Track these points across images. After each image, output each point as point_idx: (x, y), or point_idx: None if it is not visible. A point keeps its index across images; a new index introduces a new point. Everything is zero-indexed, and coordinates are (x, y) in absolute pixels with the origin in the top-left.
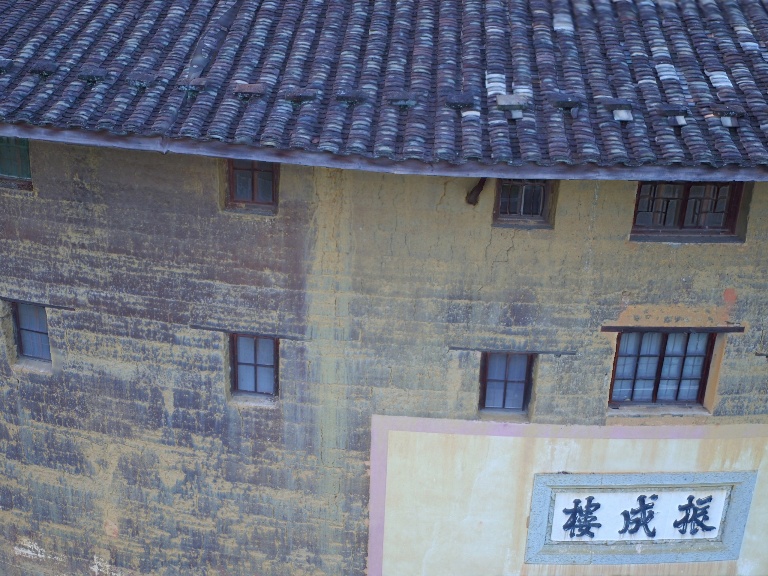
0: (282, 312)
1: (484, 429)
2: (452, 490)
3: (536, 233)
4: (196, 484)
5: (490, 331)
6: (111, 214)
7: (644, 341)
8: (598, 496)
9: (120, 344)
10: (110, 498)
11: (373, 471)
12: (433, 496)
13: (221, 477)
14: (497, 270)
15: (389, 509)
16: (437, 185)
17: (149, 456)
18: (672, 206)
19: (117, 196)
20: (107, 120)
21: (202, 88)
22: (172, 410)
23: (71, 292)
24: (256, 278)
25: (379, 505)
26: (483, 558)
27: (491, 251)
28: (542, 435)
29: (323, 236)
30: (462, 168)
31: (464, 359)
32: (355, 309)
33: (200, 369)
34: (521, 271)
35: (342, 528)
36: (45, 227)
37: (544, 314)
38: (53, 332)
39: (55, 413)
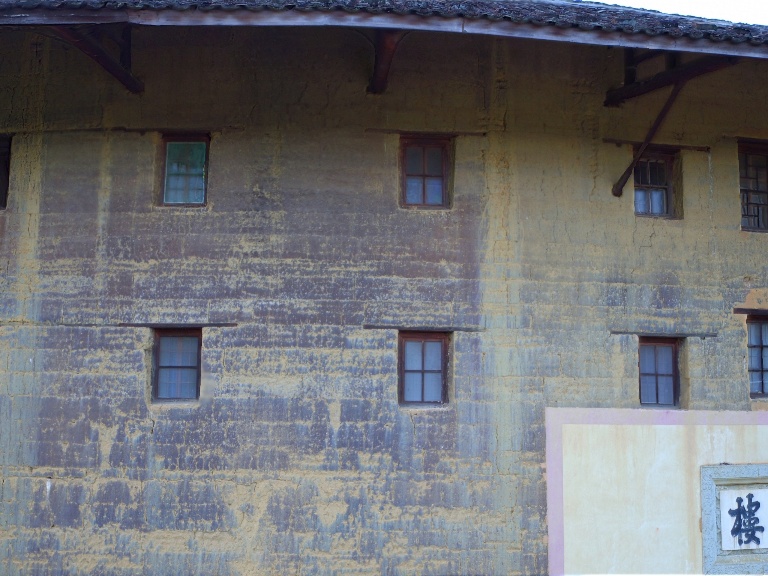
0: (457, 303)
1: (649, 418)
2: (627, 491)
3: (670, 222)
4: (360, 516)
5: (644, 314)
6: (289, 219)
7: (762, 334)
8: (756, 493)
9: (285, 356)
10: (252, 556)
11: (549, 474)
12: (609, 500)
13: (389, 502)
14: (644, 254)
15: (568, 520)
16: (588, 179)
17: (306, 489)
18: (760, 213)
19: (297, 201)
20: (414, 6)
21: (470, 8)
22: (338, 426)
23: (236, 305)
24: (432, 270)
25: (557, 516)
26: (664, 575)
27: (637, 237)
28: (700, 422)
29: (494, 226)
30: (697, 45)
31: (625, 343)
32: (525, 295)
33: (372, 373)
34: (663, 255)
35: (520, 551)
36: (215, 240)
37: (687, 296)
38: (208, 354)
39: (196, 454)
